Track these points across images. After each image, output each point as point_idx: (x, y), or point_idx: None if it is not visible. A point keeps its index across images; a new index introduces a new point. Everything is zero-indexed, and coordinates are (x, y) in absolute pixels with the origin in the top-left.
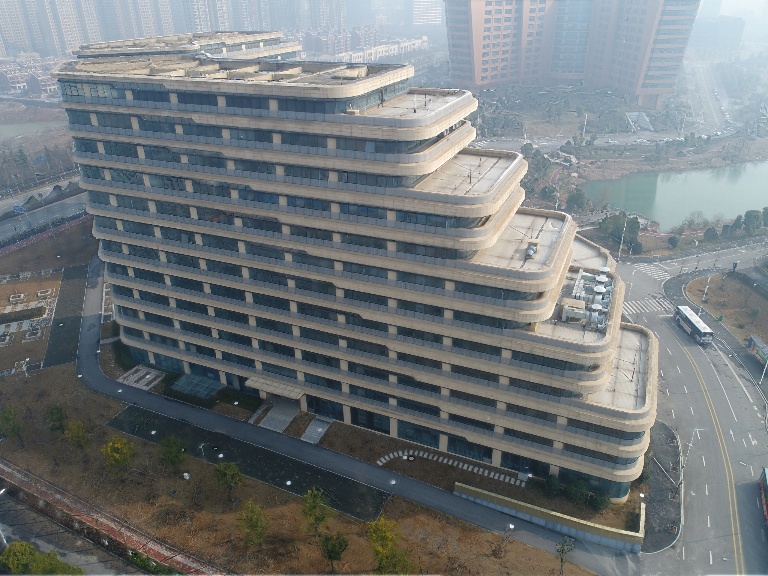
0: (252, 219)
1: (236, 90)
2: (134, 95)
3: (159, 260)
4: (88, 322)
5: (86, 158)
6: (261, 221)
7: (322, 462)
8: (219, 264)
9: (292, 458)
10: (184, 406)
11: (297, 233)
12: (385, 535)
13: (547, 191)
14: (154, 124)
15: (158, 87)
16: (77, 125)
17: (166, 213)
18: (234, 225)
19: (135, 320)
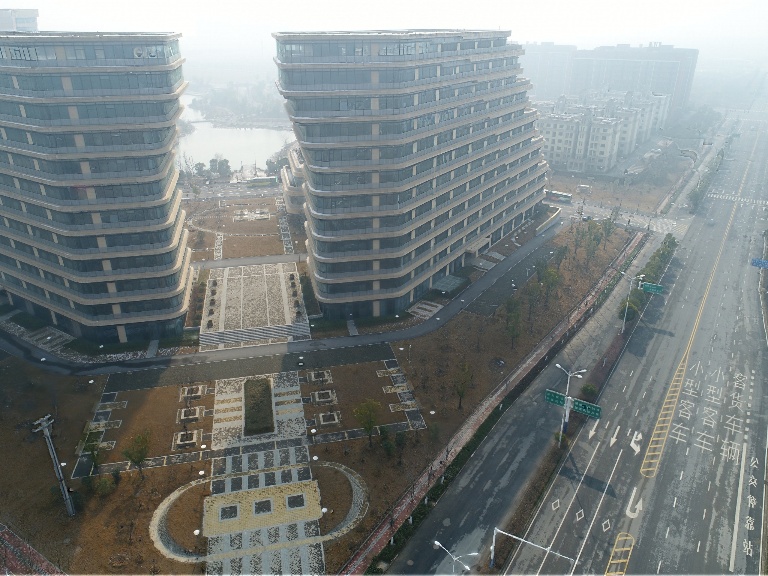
0: (476, 125)
1: (487, 36)
2: (442, 48)
3: (432, 188)
4: (305, 347)
5: (407, 113)
6: (479, 124)
7: (521, 256)
8: (459, 169)
9: (519, 262)
10: (467, 291)
11: (489, 125)
12: (595, 223)
13: (197, 169)
14: (447, 69)
15: (453, 40)
16: (406, 82)
17: (442, 142)
18: (470, 133)
19: (409, 264)
